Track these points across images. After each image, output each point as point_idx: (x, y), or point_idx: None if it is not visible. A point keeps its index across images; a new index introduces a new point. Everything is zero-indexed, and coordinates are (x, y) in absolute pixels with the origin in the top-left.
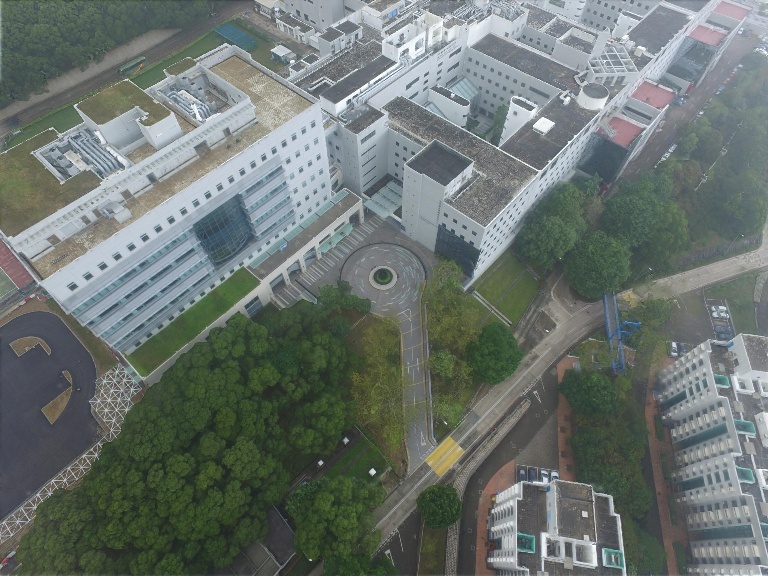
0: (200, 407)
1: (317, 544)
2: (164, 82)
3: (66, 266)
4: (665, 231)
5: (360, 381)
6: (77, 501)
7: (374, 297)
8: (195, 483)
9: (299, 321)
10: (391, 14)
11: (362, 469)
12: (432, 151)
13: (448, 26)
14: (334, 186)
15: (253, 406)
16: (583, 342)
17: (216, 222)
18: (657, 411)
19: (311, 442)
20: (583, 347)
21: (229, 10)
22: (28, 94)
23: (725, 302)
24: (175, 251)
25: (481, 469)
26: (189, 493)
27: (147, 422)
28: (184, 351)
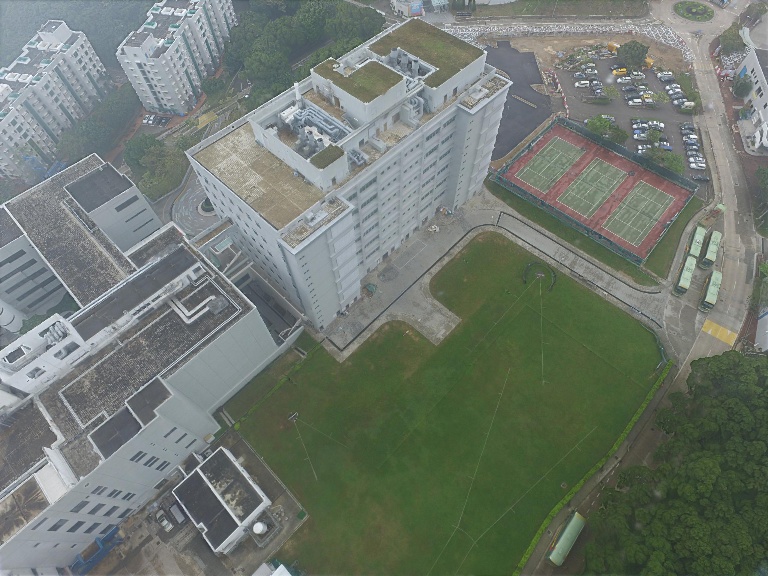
0: None
1: None
2: (343, 140)
3: None
4: None
5: None
6: None
7: None
8: None
9: None
10: None
11: None
12: None
13: None
14: None
15: None
16: None
17: None
18: None
19: None
20: None
21: None
22: None
23: None
24: None
25: None
26: None
27: None
28: None
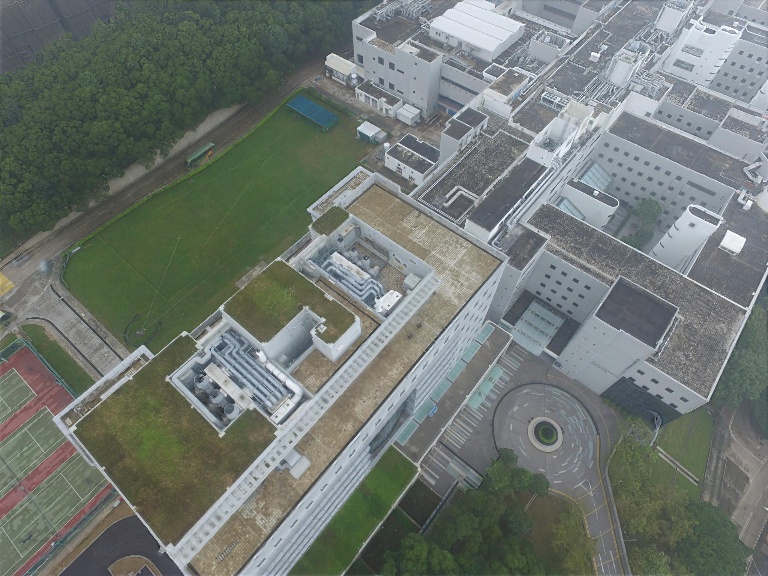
0: None
1: None
2: (314, 246)
3: (244, 572)
4: None
5: None
6: None
7: (541, 463)
8: None
9: (477, 526)
10: (514, 95)
11: None
12: (618, 291)
13: (593, 114)
14: None
15: None
16: None
17: None
18: None
19: None
20: None
21: (296, 76)
22: (88, 203)
23: None
24: None
25: None
26: None
27: None
28: None
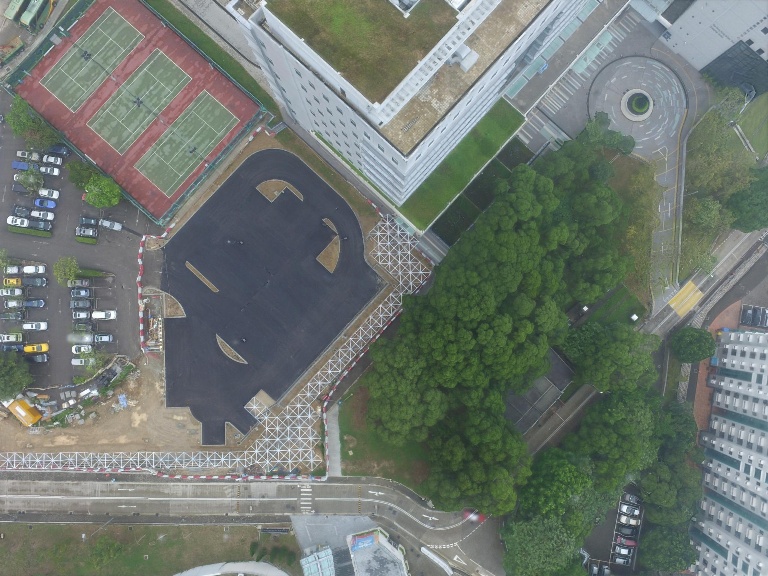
0: (515, 272)
1: (608, 381)
2: None
3: (429, 137)
4: None
5: None
6: (410, 352)
7: (627, 131)
8: (514, 338)
9: (572, 168)
10: None
11: (623, 314)
12: None
13: None
14: None
15: (552, 266)
16: None
17: None
18: None
19: (595, 296)
20: None
21: None
22: None
23: None
24: None
25: None
26: (512, 347)
27: (469, 287)
28: None
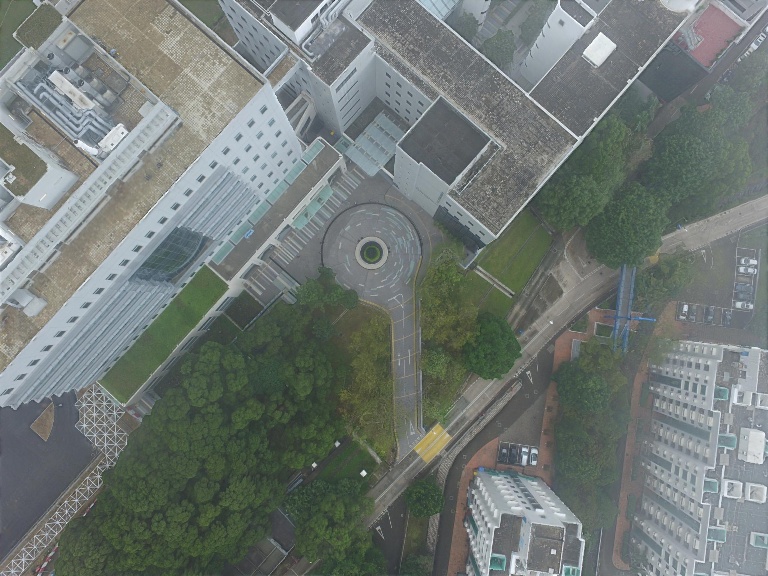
0: (187, 461)
1: (316, 552)
2: (21, 63)
3: None
4: (720, 182)
5: (348, 395)
6: (93, 538)
7: (362, 279)
8: (198, 523)
9: (278, 334)
10: None
11: (354, 469)
12: (435, 115)
13: None
14: (305, 126)
15: (241, 445)
16: (588, 312)
17: (158, 256)
18: (647, 378)
19: (303, 464)
20: (586, 347)
21: None
22: None
23: (759, 253)
24: (116, 306)
25: (466, 446)
26: (194, 533)
27: (138, 479)
28: (159, 371)
